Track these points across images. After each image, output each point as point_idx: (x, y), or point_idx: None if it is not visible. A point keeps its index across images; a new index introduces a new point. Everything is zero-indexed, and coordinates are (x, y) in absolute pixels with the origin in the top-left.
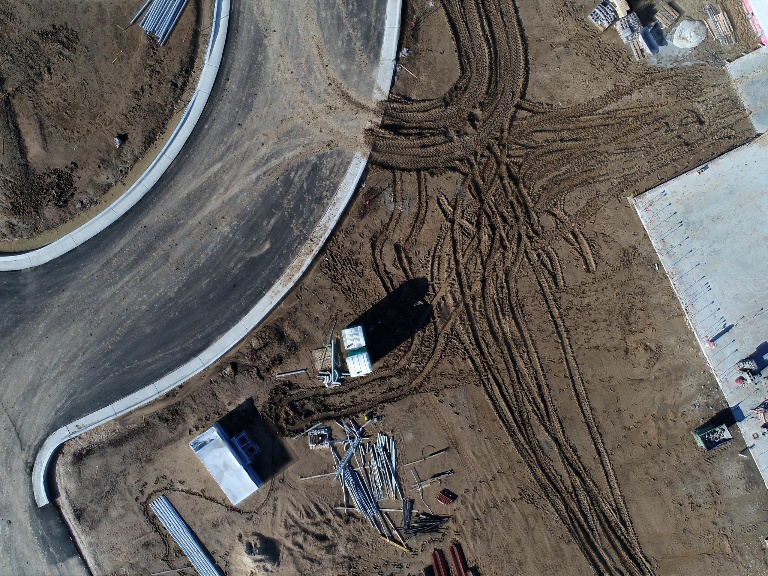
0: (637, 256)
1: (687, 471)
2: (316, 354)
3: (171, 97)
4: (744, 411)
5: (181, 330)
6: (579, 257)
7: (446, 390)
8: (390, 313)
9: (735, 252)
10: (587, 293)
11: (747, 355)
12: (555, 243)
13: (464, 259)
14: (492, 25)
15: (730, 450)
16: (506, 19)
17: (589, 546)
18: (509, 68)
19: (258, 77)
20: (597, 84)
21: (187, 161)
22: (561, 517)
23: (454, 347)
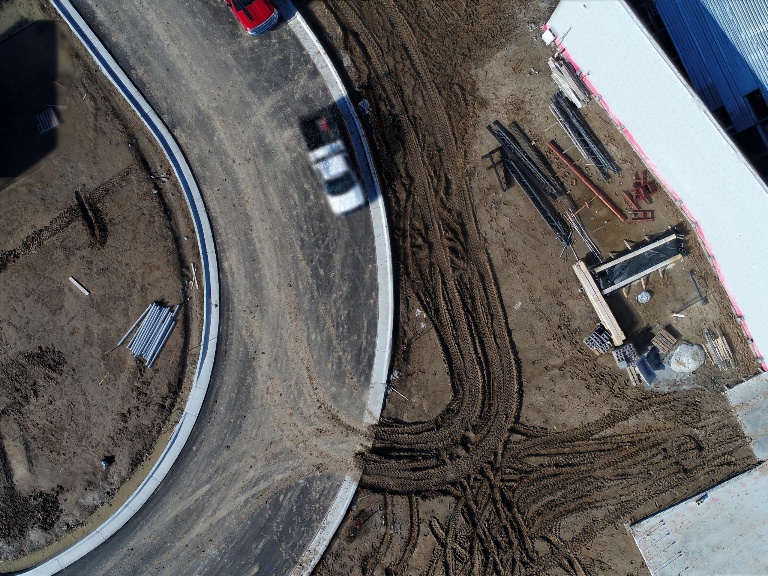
0: None
1: None
2: None
3: (158, 419)
4: None
5: None
6: None
7: None
8: None
9: None
10: None
11: None
12: (550, 569)
13: None
14: (485, 347)
15: None
16: (499, 341)
17: None
18: (502, 390)
19: (247, 399)
20: (593, 408)
21: (175, 483)
22: None
23: None
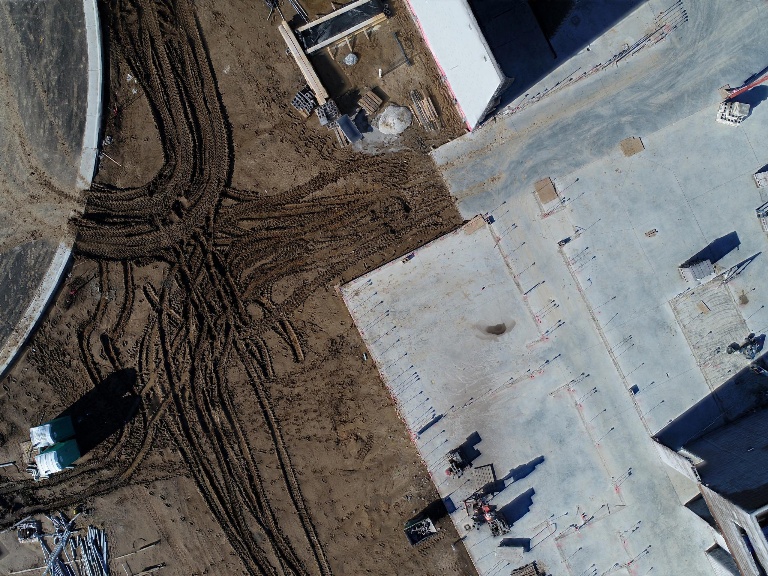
0: (345, 346)
1: (401, 563)
2: (23, 447)
3: None
4: (455, 502)
5: None
6: (288, 347)
7: (157, 482)
8: (99, 404)
9: (443, 341)
10: (296, 383)
11: (457, 446)
12: (263, 333)
13: (172, 349)
14: (196, 112)
15: (444, 541)
16: (210, 106)
17: None
18: (214, 155)
19: None
20: (302, 171)
21: None
22: None
23: (164, 438)
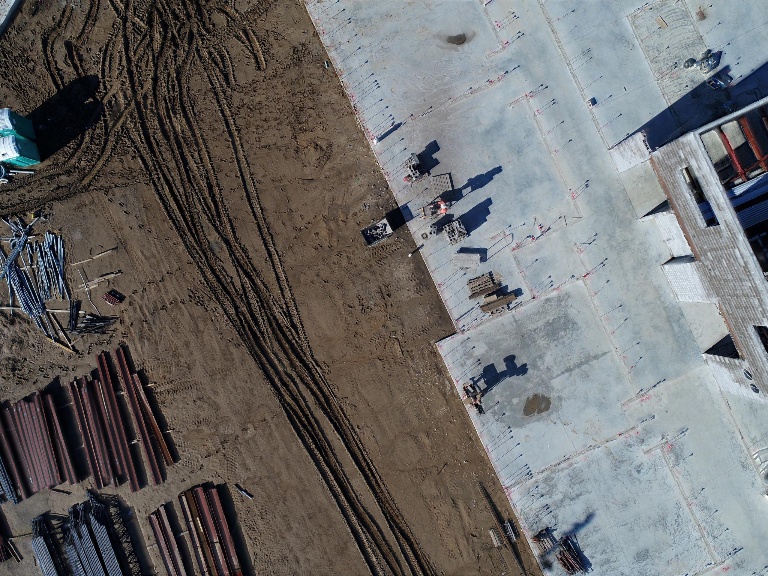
0: (307, 54)
1: (358, 273)
2: None
3: None
4: (413, 211)
5: None
6: (250, 55)
7: (116, 189)
8: (60, 110)
9: (404, 50)
10: (258, 91)
11: None
12: (226, 41)
13: (136, 57)
14: None
15: (401, 251)
16: None
17: (259, 349)
18: None
19: None
20: None
21: None
22: (231, 320)
23: (125, 145)
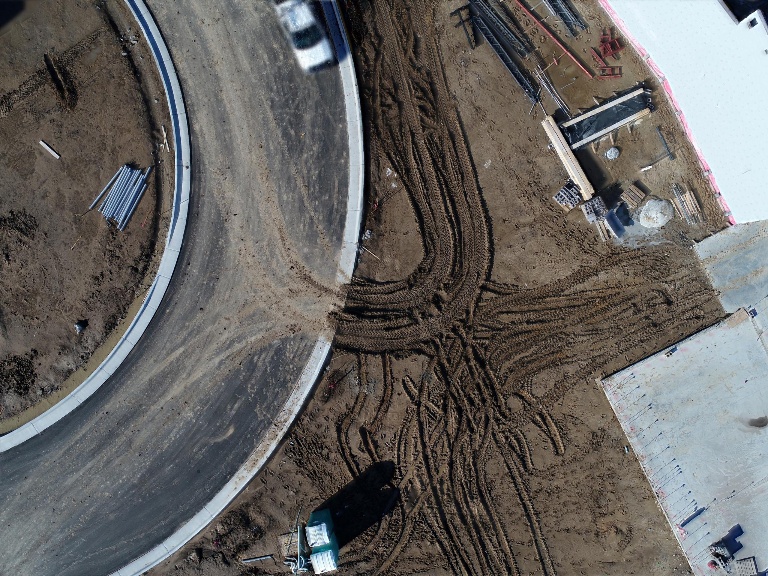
0: (606, 438)
1: None
2: (282, 540)
3: (131, 282)
4: None
5: (145, 517)
6: (547, 439)
7: (414, 574)
8: (356, 497)
9: (705, 434)
10: (556, 475)
11: (719, 538)
12: (523, 425)
13: (431, 442)
14: (456, 206)
15: None
16: (470, 199)
17: None
18: (474, 249)
19: (219, 261)
20: (563, 265)
21: (149, 346)
22: None
23: (422, 530)
